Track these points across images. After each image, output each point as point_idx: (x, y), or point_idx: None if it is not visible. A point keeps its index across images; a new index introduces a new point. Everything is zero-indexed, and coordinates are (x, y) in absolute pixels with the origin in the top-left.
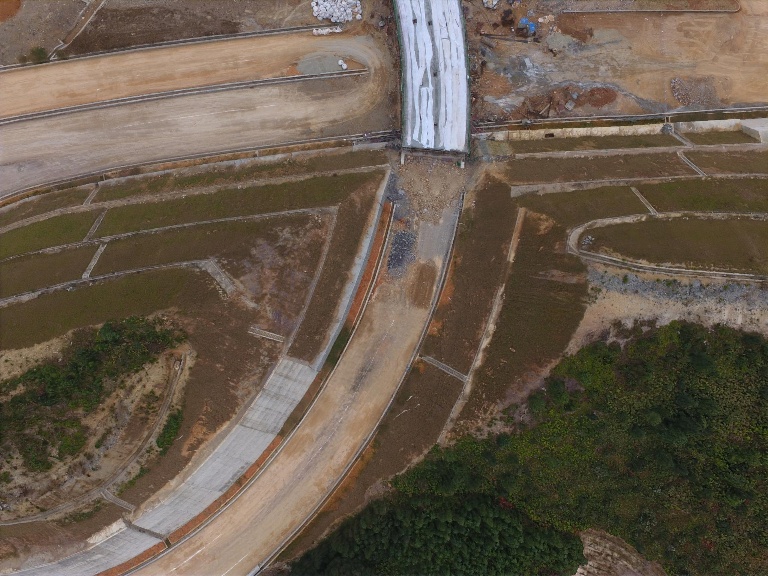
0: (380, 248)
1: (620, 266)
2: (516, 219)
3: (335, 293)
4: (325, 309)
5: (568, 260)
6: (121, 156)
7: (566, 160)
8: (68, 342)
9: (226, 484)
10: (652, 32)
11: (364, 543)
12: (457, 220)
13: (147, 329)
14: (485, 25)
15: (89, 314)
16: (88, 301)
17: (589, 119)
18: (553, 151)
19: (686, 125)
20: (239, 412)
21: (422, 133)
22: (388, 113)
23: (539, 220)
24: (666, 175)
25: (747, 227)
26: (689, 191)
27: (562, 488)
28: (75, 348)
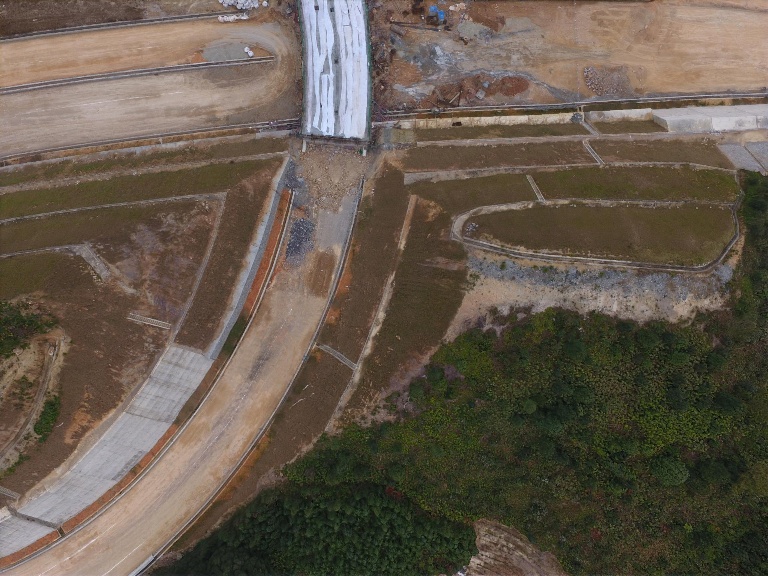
0: (278, 236)
1: (499, 252)
2: (407, 206)
3: (228, 281)
4: (217, 297)
5: (451, 247)
6: (22, 143)
7: (467, 148)
8: None
9: (119, 473)
10: (565, 21)
11: (249, 532)
12: (356, 208)
13: (11, 313)
14: (395, 13)
15: None
16: None
17: (500, 108)
18: (455, 139)
19: (597, 114)
20: (125, 400)
21: (322, 120)
22: (295, 101)
23: (428, 207)
24: (563, 163)
25: (634, 214)
26: (583, 179)
27: (451, 477)
28: None
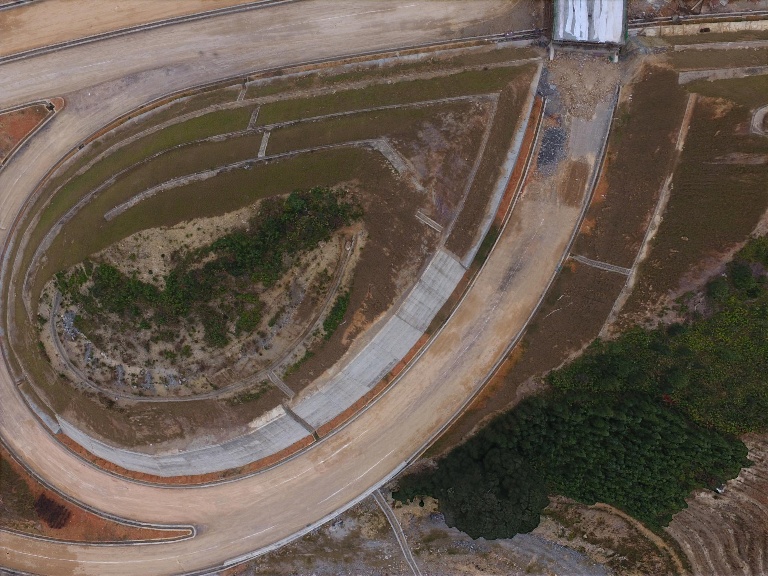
0: (530, 145)
1: None
2: (686, 105)
3: (489, 187)
4: (479, 203)
5: (753, 141)
6: (264, 59)
7: (731, 50)
8: (256, 212)
9: (374, 380)
10: None
11: (523, 434)
12: (612, 115)
13: (330, 201)
14: None
15: (273, 186)
16: (268, 177)
17: (745, 15)
18: (715, 42)
19: None
20: (396, 303)
21: (575, 25)
22: (531, 11)
23: (714, 104)
24: None
25: None
26: None
27: (731, 385)
28: (264, 216)
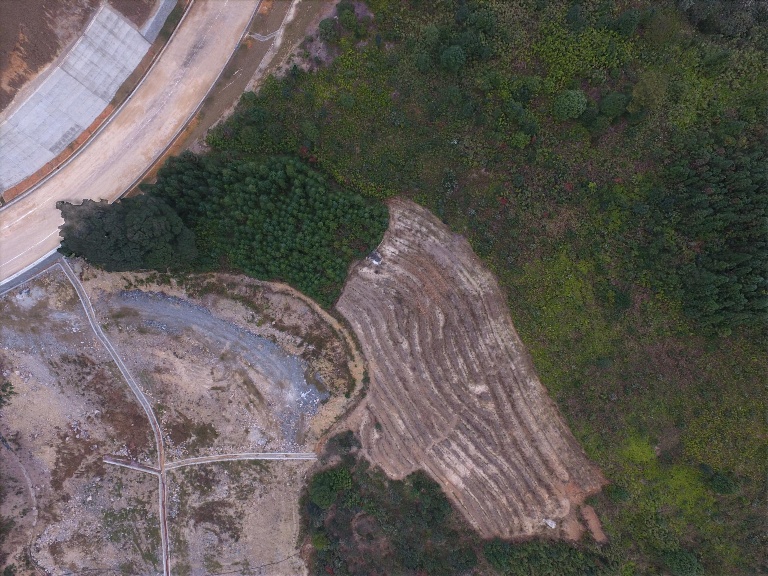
0: None
1: None
2: None
3: None
4: None
5: None
6: None
7: None
8: None
9: (57, 145)
10: None
11: (167, 180)
12: None
13: None
14: None
15: None
16: None
17: None
18: None
19: None
20: (60, 55)
21: None
22: None
23: None
24: None
25: None
26: None
27: (363, 141)
28: None
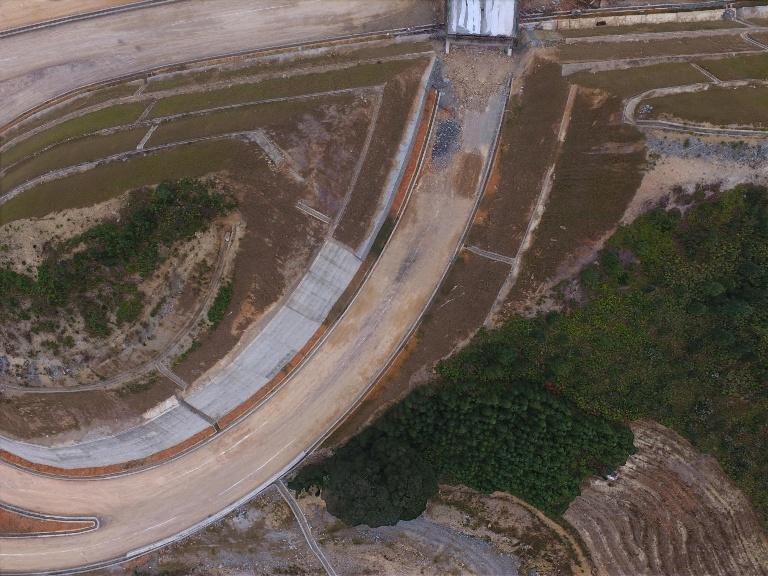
0: (424, 137)
1: (681, 131)
2: (567, 97)
3: (380, 179)
4: (370, 194)
5: (624, 130)
6: (168, 55)
7: (620, 43)
8: (125, 203)
9: (272, 371)
10: None
11: (409, 423)
12: (504, 107)
13: (200, 192)
14: None
15: (145, 177)
16: (143, 168)
17: (643, 8)
18: (606, 35)
19: (750, 10)
20: (286, 293)
21: (468, 19)
22: (432, 6)
23: (592, 95)
24: (730, 51)
25: None
26: (755, 64)
27: (613, 372)
28: (132, 207)
